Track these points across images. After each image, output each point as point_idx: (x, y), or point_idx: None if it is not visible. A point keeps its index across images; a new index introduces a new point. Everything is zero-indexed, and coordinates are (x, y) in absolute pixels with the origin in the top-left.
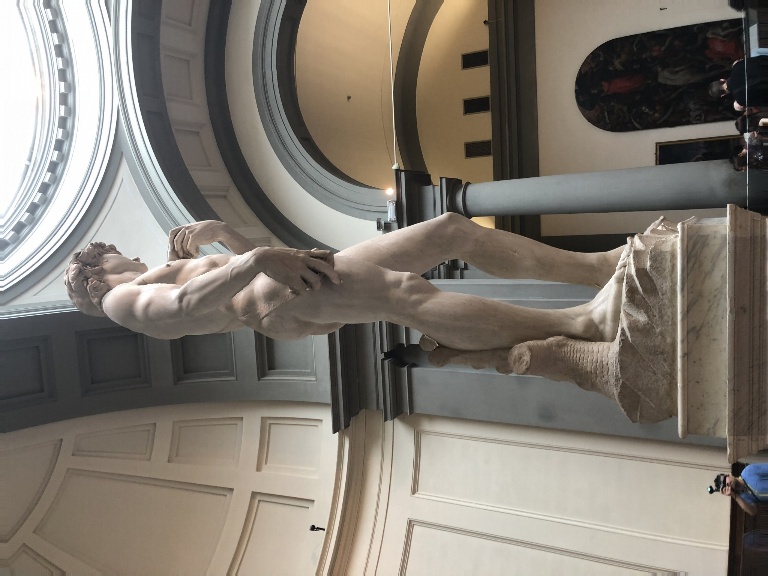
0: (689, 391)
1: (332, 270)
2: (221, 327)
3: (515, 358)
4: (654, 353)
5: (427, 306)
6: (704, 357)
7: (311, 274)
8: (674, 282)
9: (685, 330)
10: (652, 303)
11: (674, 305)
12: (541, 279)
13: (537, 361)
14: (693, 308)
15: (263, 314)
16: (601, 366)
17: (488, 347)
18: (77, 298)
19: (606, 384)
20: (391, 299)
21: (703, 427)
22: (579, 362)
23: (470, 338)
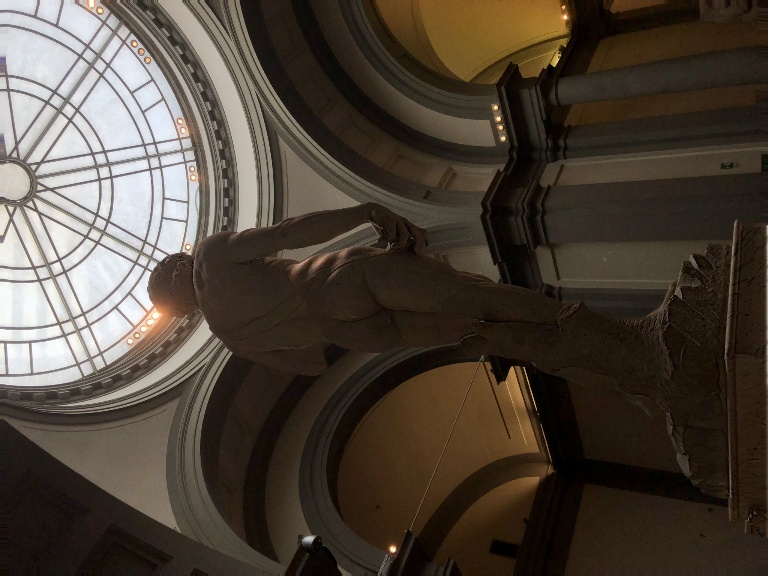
0: (738, 321)
1: (421, 237)
2: (276, 303)
3: (564, 309)
4: (704, 305)
5: (490, 282)
6: (755, 298)
7: (405, 228)
8: (728, 260)
9: (737, 279)
10: (706, 273)
11: (727, 274)
12: (584, 378)
13: (585, 312)
14: (745, 267)
15: (336, 267)
16: (649, 320)
17: (535, 319)
18: (161, 271)
19: (651, 331)
20: (458, 275)
21: (752, 348)
22: (626, 322)
23: (522, 302)
